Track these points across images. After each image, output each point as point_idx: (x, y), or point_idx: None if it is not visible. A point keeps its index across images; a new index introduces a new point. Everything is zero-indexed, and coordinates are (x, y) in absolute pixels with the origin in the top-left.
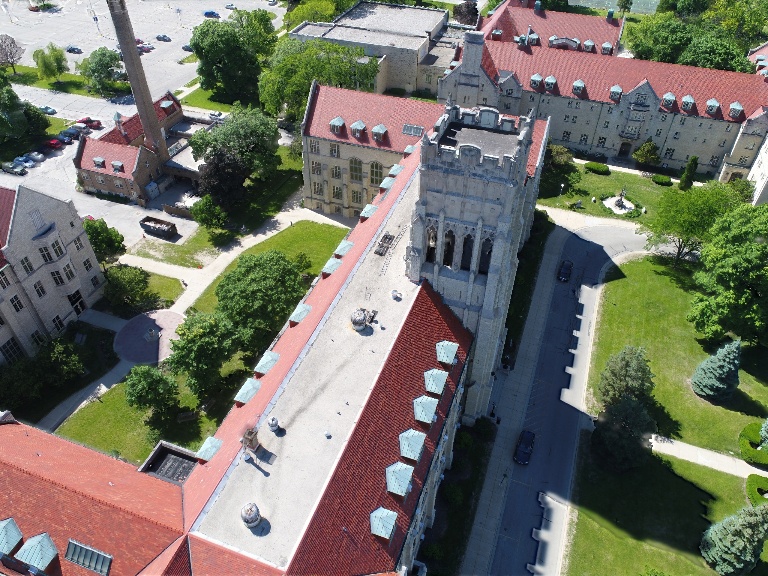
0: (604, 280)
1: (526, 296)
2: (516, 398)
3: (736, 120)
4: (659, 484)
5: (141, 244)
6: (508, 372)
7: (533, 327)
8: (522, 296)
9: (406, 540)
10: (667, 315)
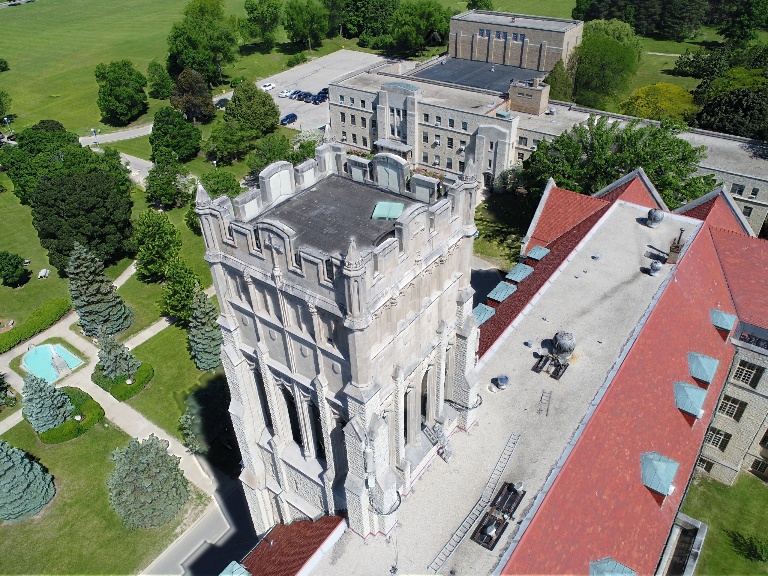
0: None
1: None
2: None
3: None
4: None
5: None
6: None
7: None
8: None
9: None
10: None
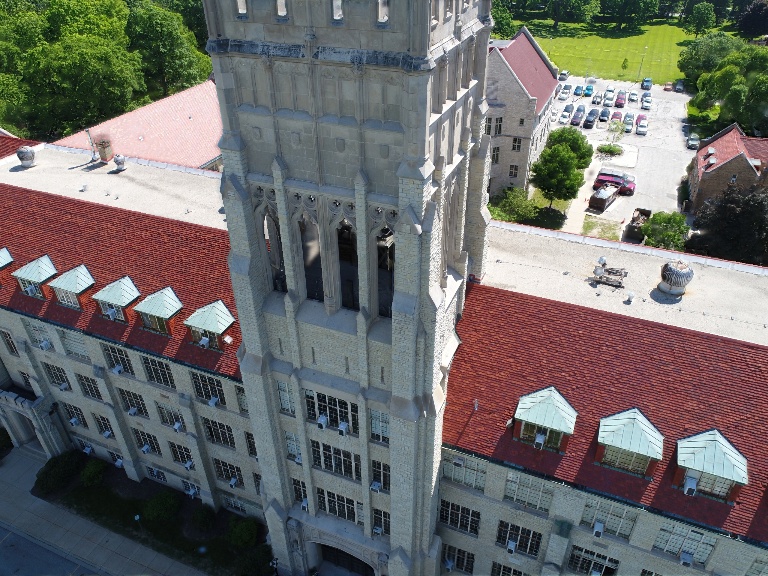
0: None
1: None
2: None
3: None
4: None
5: (608, 222)
6: None
7: None
8: None
9: (16, 333)
10: None
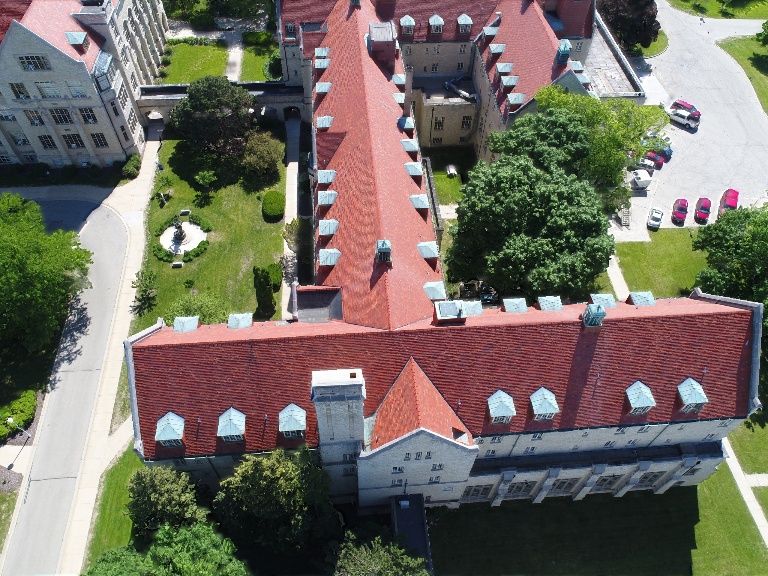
0: None
1: None
2: None
3: (318, 275)
4: None
5: None
6: None
7: None
8: None
9: None
10: None
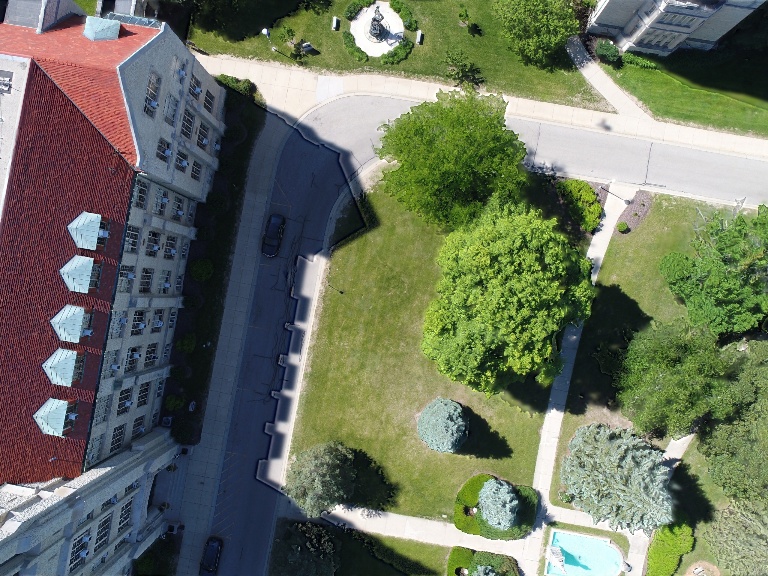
0: (332, 240)
1: (216, 300)
2: (203, 487)
3: None
4: (356, 574)
5: None
6: (190, 454)
7: (225, 361)
8: (210, 301)
9: None
10: (412, 299)
